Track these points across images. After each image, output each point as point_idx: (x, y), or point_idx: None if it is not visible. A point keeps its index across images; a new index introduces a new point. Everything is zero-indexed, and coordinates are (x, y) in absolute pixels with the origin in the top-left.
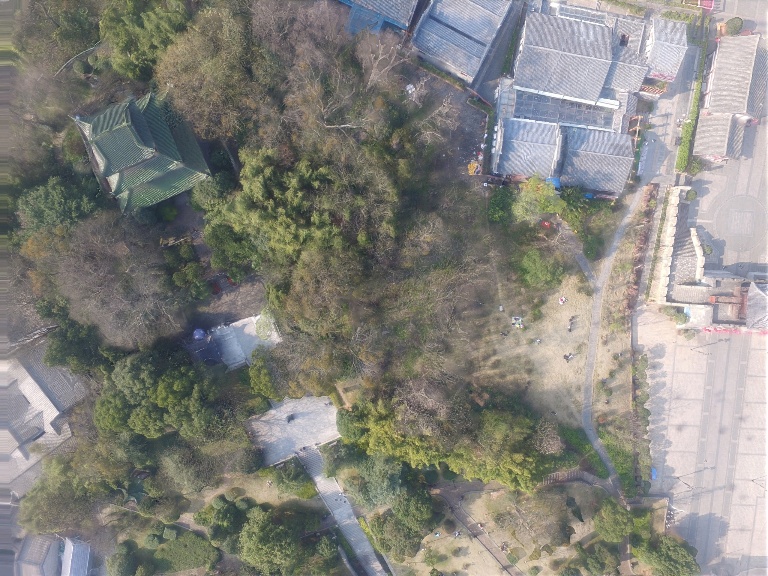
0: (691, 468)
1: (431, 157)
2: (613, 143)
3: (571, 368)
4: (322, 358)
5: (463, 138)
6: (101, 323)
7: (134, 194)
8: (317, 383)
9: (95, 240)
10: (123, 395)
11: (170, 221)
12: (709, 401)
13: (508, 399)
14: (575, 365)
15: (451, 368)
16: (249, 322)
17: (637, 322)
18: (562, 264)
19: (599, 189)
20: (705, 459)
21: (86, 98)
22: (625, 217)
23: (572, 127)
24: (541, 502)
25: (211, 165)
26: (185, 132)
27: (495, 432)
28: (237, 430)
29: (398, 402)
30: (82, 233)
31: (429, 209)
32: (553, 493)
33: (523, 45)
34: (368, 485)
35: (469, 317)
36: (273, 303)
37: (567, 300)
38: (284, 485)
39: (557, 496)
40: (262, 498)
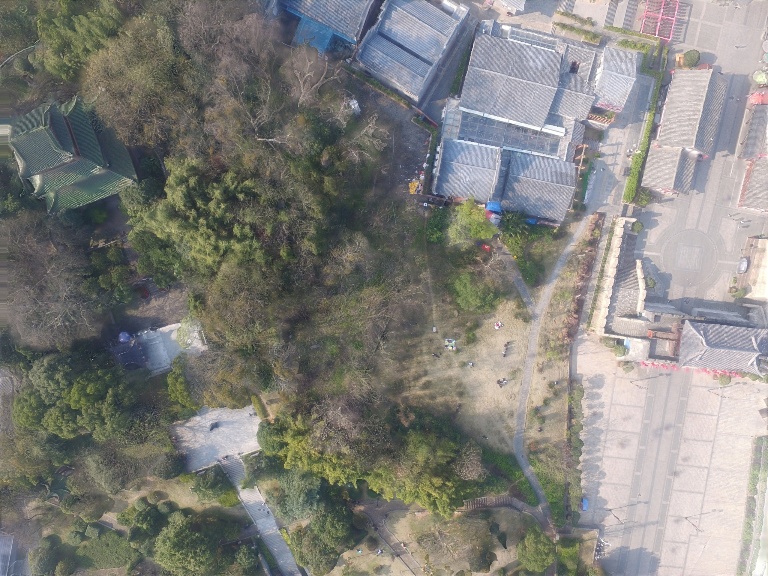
0: (624, 501)
1: (370, 174)
2: (556, 170)
3: (504, 393)
4: (234, 371)
5: (406, 156)
6: (17, 322)
7: (58, 195)
8: (228, 396)
9: (14, 239)
10: (39, 394)
11: (100, 223)
12: (646, 435)
13: (437, 421)
14: (509, 391)
15: (379, 386)
16: (176, 328)
17: (577, 351)
18: (493, 290)
19: (540, 216)
20: (639, 493)
21: (25, 95)
22: (568, 245)
23: (516, 152)
24: (466, 526)
25: (140, 171)
26: (113, 137)
27: (418, 454)
28: (161, 434)
29: (318, 418)
30: (2, 232)
31: (360, 227)
32: (479, 518)
33: (468, 67)
34: (286, 498)
35: (401, 336)
36: (192, 312)
37: (503, 325)
38: (201, 493)
39: (483, 521)
40: (185, 503)
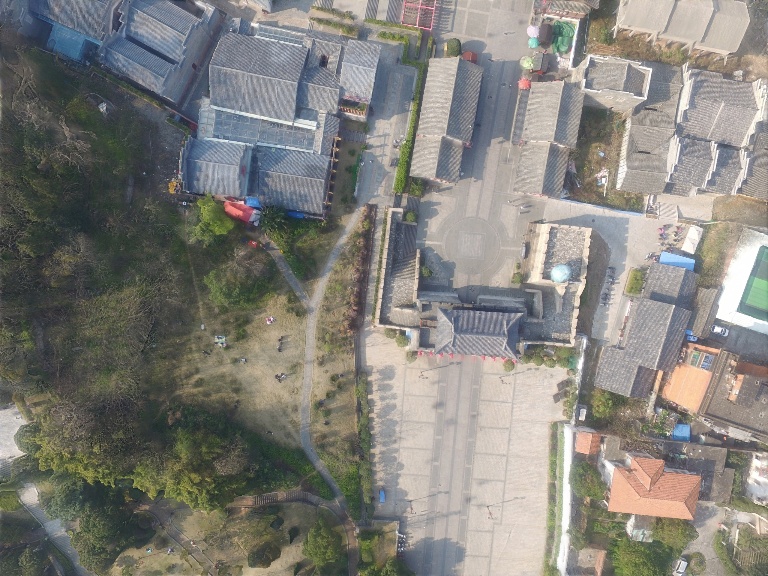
0: (425, 492)
1: (122, 175)
2: (308, 164)
3: (285, 388)
4: None
5: (163, 156)
6: None
7: None
8: None
9: None
10: None
11: None
12: (441, 425)
13: (212, 418)
14: (290, 385)
15: (145, 385)
16: None
17: (365, 343)
18: (239, 285)
19: (299, 210)
20: (439, 483)
21: None
22: (340, 238)
23: (271, 147)
24: (255, 522)
25: None
26: None
27: (183, 451)
28: None
29: (67, 419)
30: None
31: (97, 228)
32: (266, 513)
33: (209, 65)
34: (52, 500)
35: (168, 335)
36: None
37: (275, 320)
38: None
39: (272, 516)
40: None
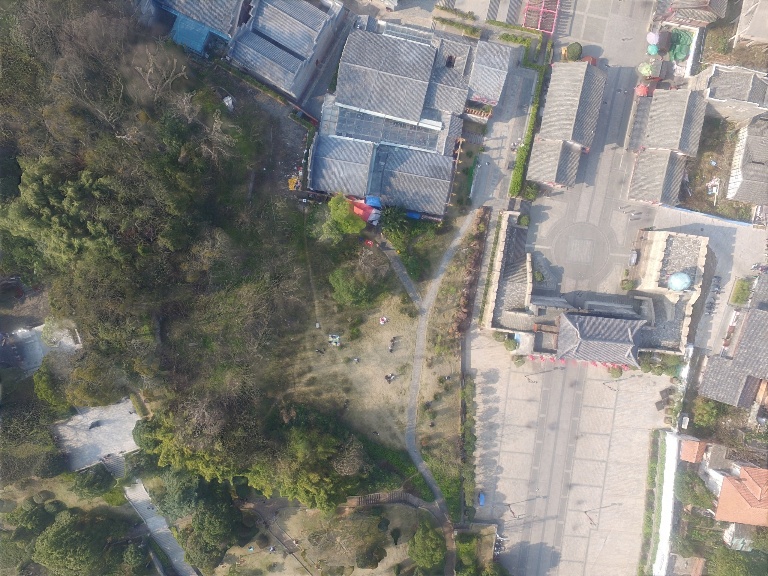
0: (523, 496)
1: (246, 170)
2: (433, 165)
3: (394, 389)
4: (87, 369)
5: (284, 152)
6: None
7: None
8: (84, 393)
9: None
10: None
11: None
12: (543, 429)
13: (323, 417)
14: (398, 386)
15: (260, 383)
16: None
17: (470, 345)
18: (366, 285)
19: (419, 210)
20: (537, 488)
21: None
22: (455, 239)
23: (394, 147)
24: (359, 522)
25: None
26: None
27: (299, 450)
28: (42, 434)
29: (190, 415)
30: None
31: (227, 223)
32: (370, 514)
33: None
34: (165, 496)
35: (283, 333)
36: None
37: (389, 320)
38: (78, 492)
39: (376, 517)
40: (72, 502)
